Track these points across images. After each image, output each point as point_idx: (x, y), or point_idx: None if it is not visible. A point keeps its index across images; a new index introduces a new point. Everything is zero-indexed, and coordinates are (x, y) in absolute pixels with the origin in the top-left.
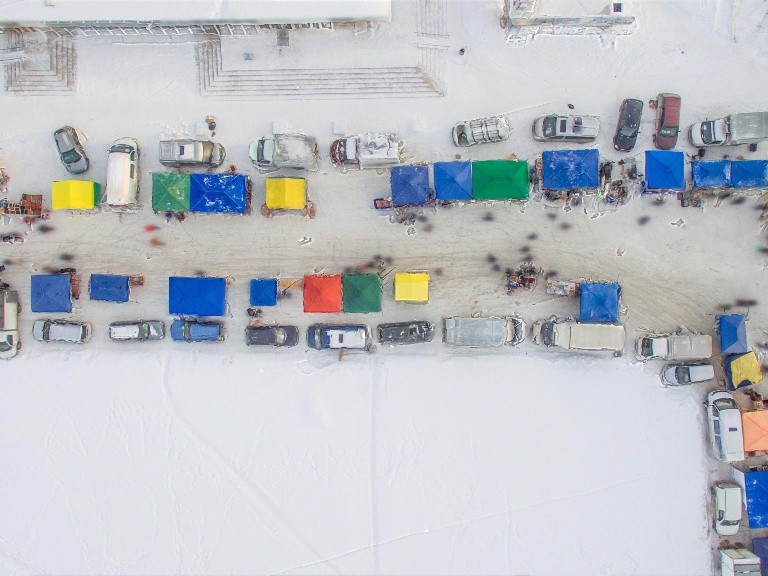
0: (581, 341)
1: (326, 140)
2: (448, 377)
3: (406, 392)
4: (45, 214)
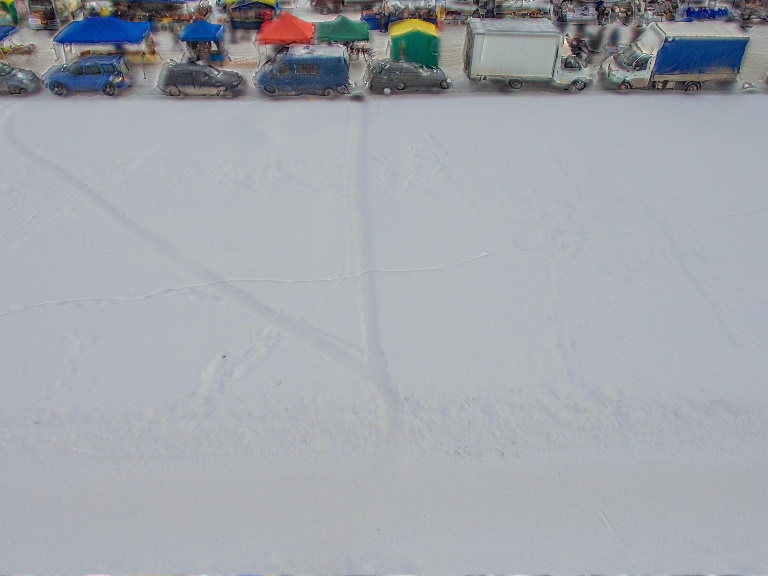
0: (679, 30)
1: None
2: (482, 113)
3: (413, 116)
4: None
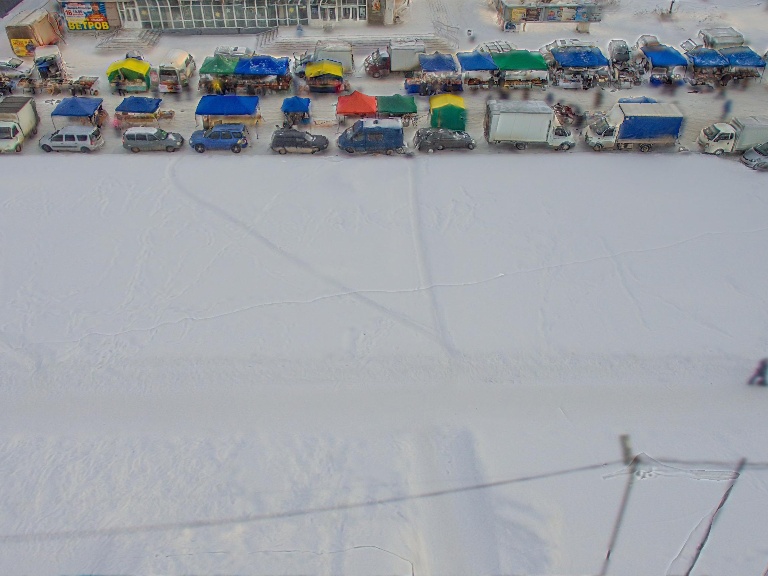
0: (635, 111)
1: (360, 65)
2: (498, 170)
3: (451, 174)
4: (94, 90)
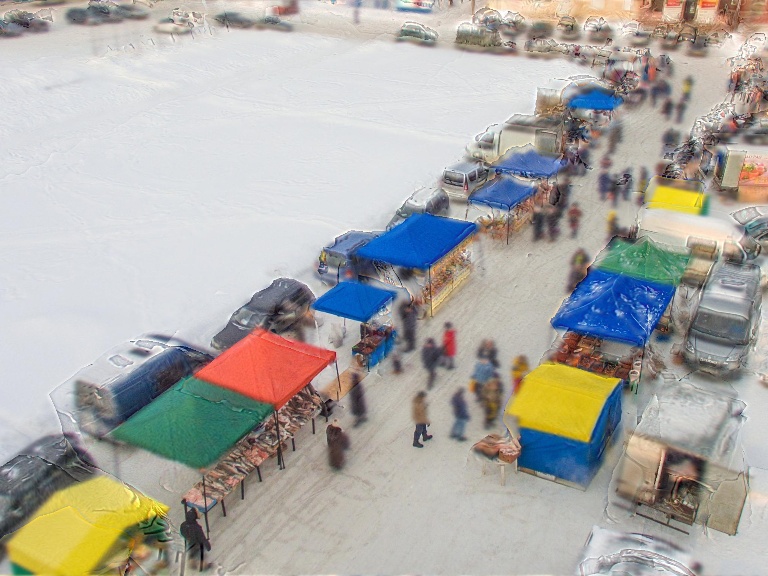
0: None
1: None
2: None
3: None
4: None
